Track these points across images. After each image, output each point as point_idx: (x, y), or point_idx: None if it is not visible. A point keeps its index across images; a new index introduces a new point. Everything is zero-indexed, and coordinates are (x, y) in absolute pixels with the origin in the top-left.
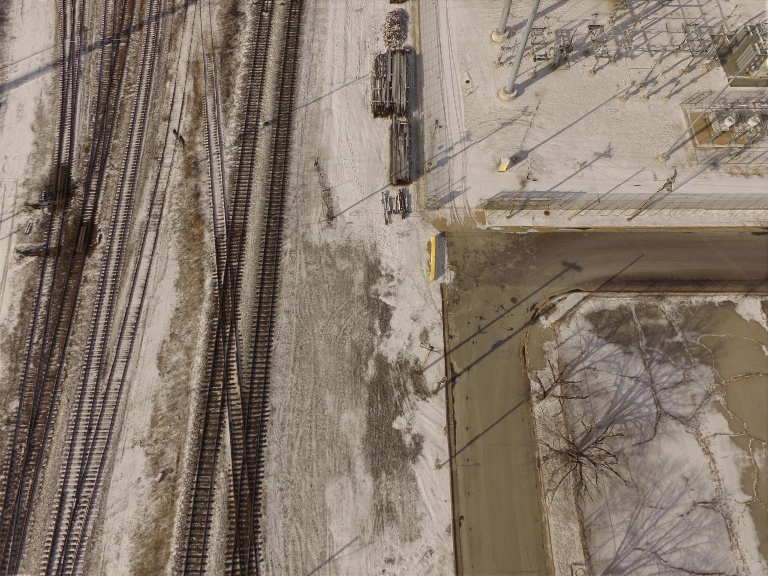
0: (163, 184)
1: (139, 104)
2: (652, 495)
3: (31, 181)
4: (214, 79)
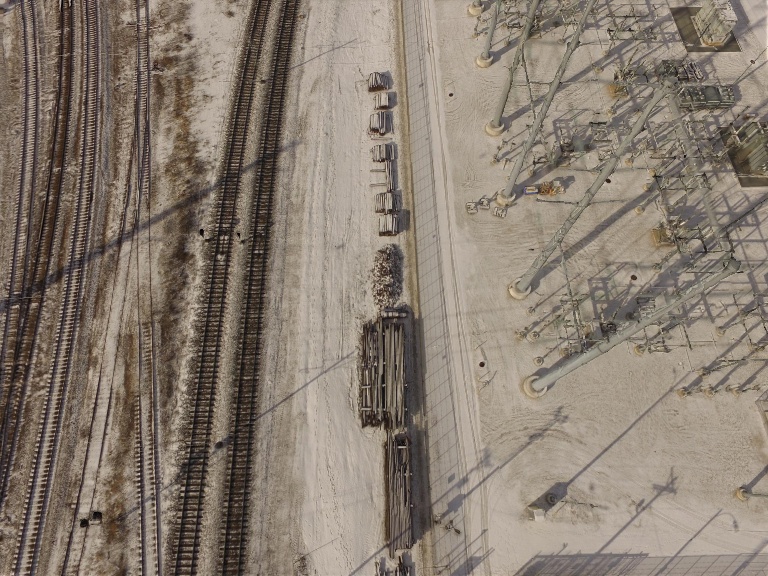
0: (76, 552)
1: (50, 409)
2: None
3: None
4: (152, 367)
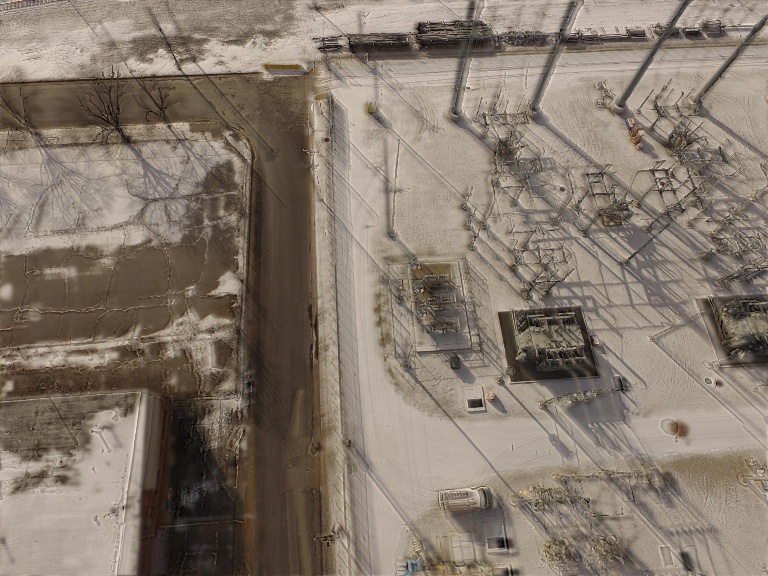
0: None
1: None
2: (91, 188)
3: None
4: None
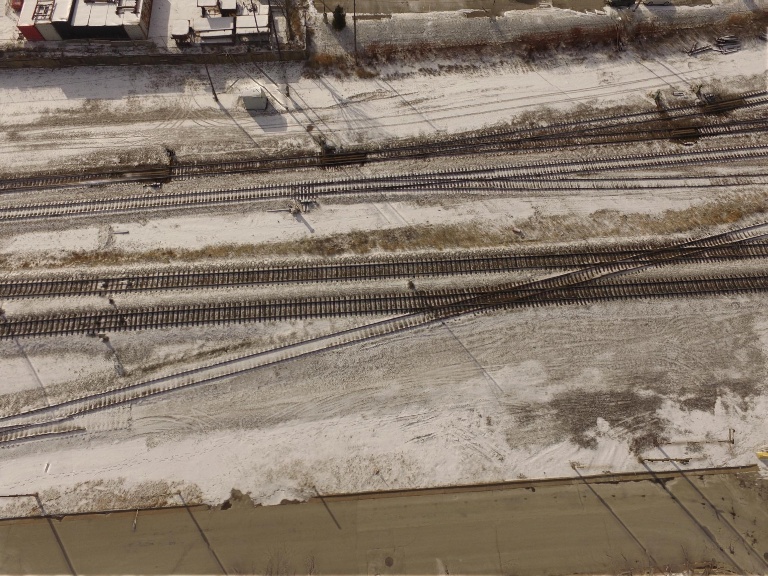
0: (759, 180)
1: None
2: None
3: (719, 84)
4: None
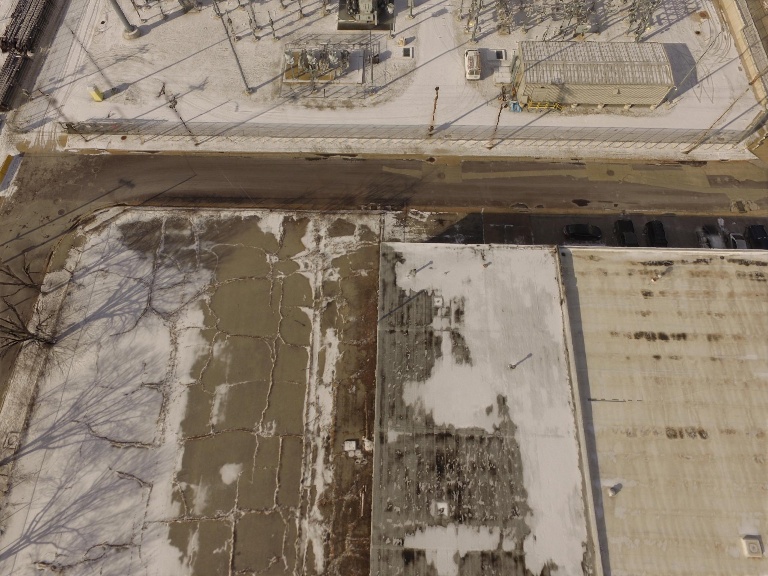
0: None
1: None
2: (108, 377)
3: None
4: None
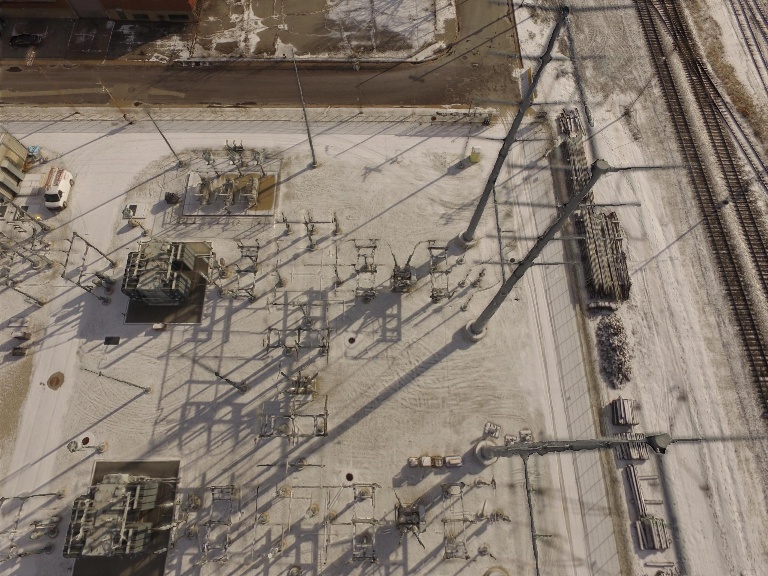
0: None
1: None
2: None
3: None
4: None
